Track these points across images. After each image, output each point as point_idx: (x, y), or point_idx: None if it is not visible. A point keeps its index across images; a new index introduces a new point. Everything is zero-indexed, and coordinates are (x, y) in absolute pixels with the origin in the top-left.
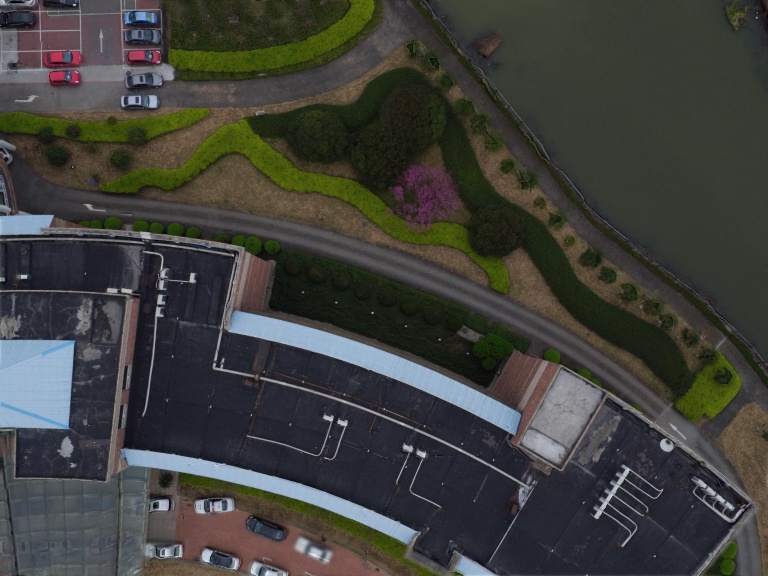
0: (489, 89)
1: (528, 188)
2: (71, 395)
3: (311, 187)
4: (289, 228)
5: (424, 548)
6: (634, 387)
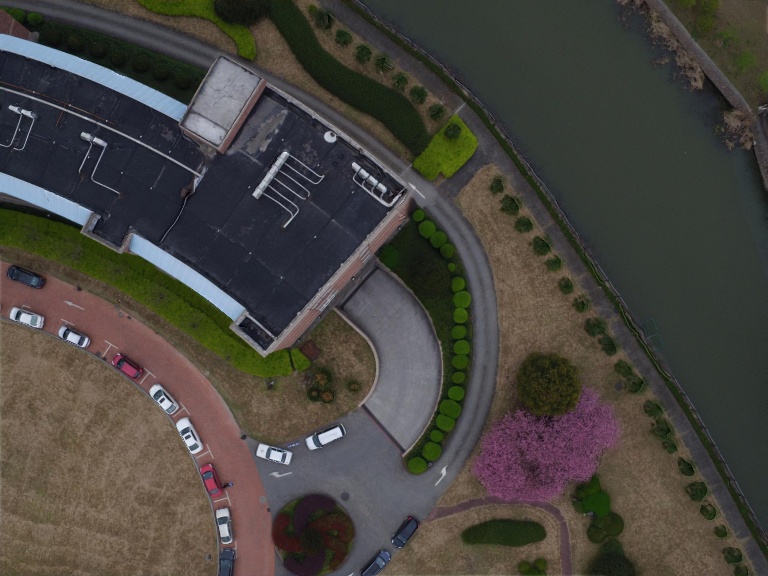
0: None
1: None
2: None
3: None
4: (53, 3)
5: (104, 232)
6: (375, 149)
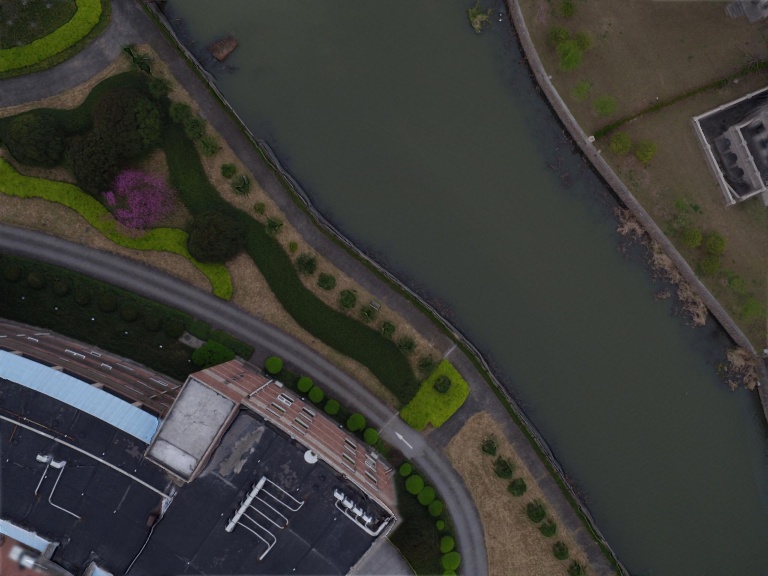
0: (218, 93)
1: (245, 193)
2: None
3: (32, 192)
4: (11, 233)
5: (64, 559)
6: (360, 395)
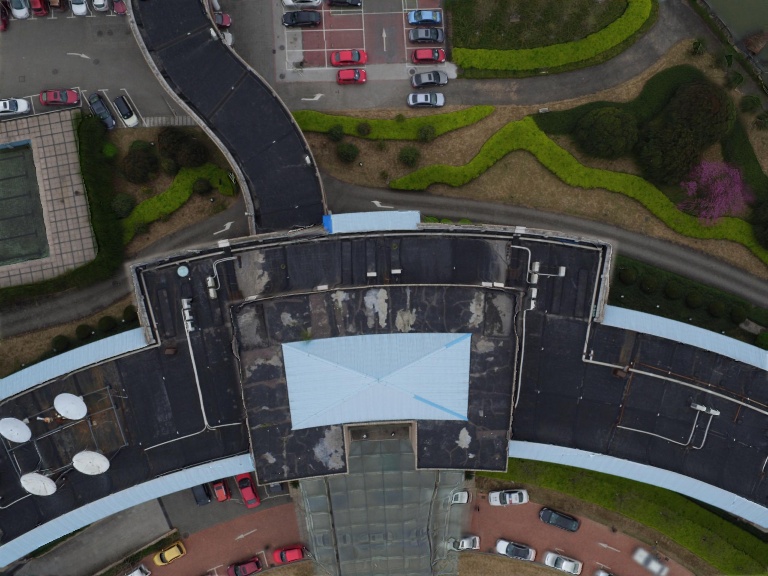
0: (763, 86)
1: None
2: (469, 387)
3: (597, 183)
4: (574, 223)
5: None
6: None
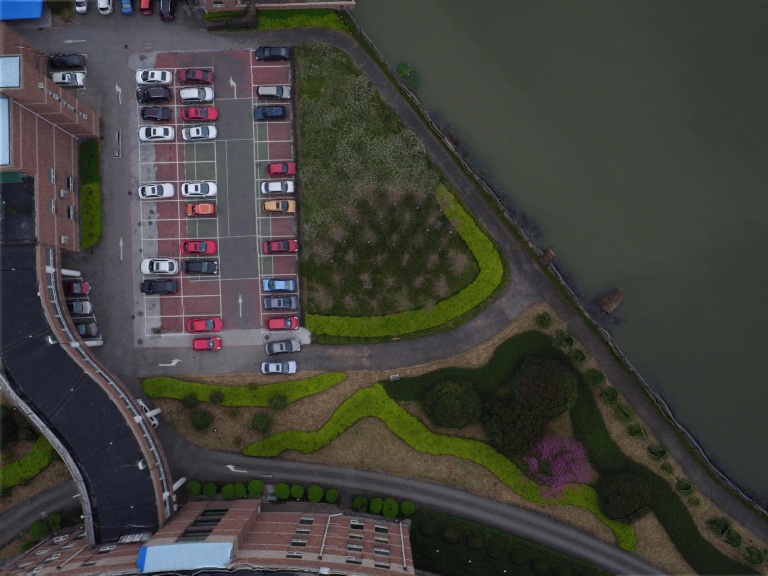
0: (614, 349)
1: (657, 456)
2: None
3: (445, 450)
4: (423, 488)
5: None
6: None
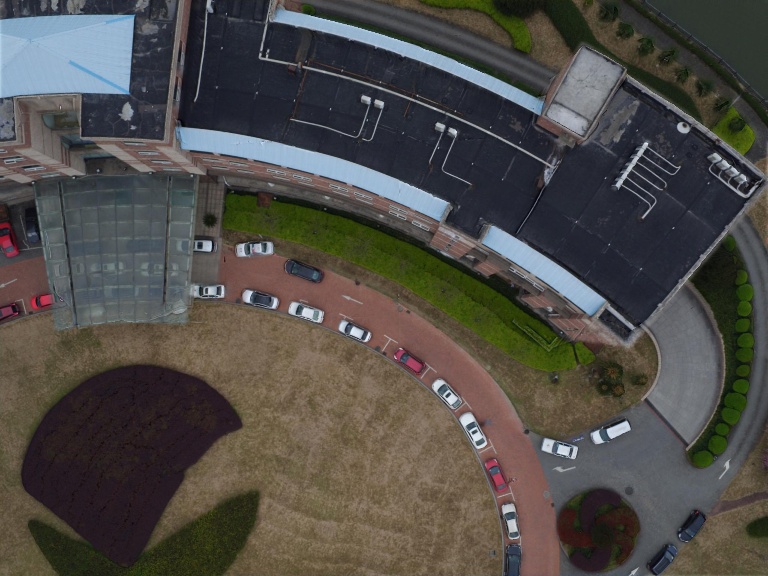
0: None
1: None
2: (131, 63)
3: None
4: None
5: (456, 224)
6: None
